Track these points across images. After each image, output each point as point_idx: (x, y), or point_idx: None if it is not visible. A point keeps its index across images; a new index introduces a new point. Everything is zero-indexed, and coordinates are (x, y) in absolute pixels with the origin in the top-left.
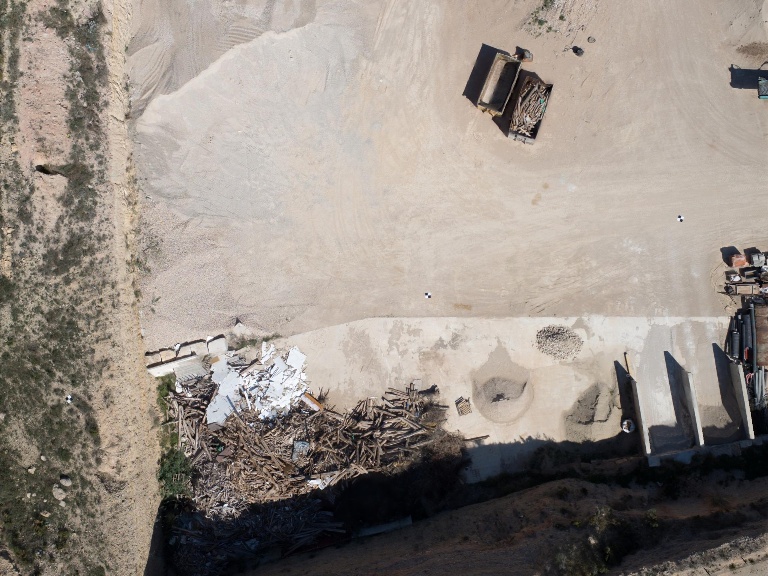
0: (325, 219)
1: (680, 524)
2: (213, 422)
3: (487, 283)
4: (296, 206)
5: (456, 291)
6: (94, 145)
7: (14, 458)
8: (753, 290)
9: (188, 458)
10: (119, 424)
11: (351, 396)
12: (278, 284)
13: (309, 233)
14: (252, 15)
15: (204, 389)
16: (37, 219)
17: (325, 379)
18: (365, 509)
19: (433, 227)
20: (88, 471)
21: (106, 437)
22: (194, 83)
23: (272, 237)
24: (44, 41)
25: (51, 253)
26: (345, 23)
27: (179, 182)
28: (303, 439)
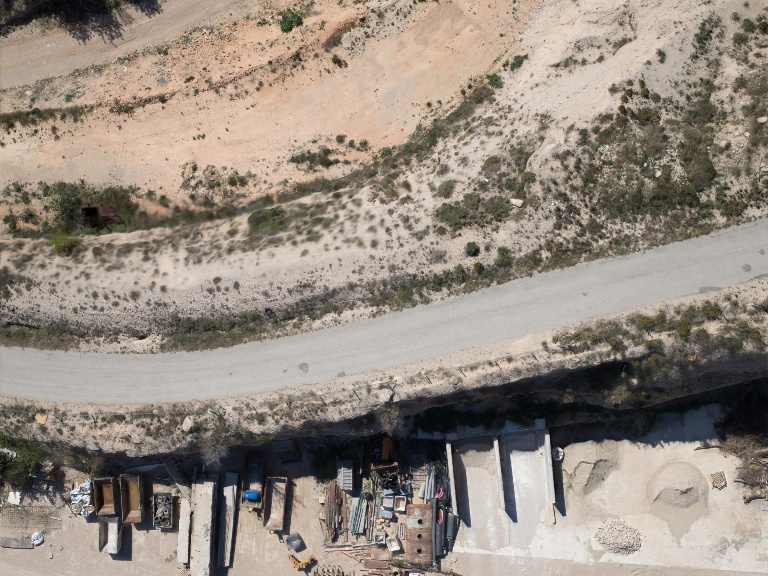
0: None
1: (543, 388)
2: None
3: None
4: None
5: None
6: None
7: None
8: None
9: None
10: None
11: None
12: None
13: None
14: None
15: None
16: None
17: None
18: None
19: None
20: None
21: None
22: None
23: None
24: None
25: None
26: None
27: None
28: None
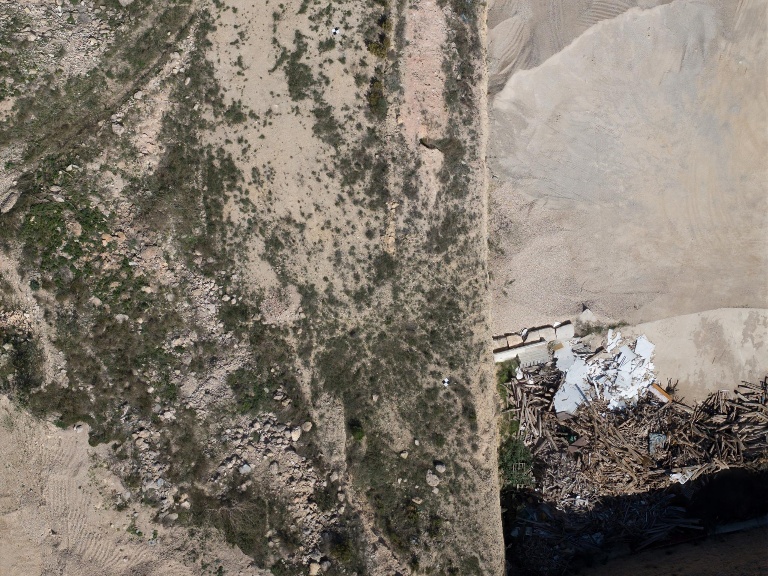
0: (677, 204)
1: None
2: (563, 411)
3: None
4: (647, 190)
5: None
6: (467, 120)
7: (385, 442)
8: None
9: (527, 447)
10: (489, 410)
11: (701, 388)
12: (625, 270)
13: (660, 218)
14: None
15: (548, 376)
16: (422, 194)
17: (674, 370)
18: (725, 506)
19: None
20: (463, 457)
21: (481, 423)
22: (553, 59)
23: (620, 221)
24: (426, 10)
25: (434, 230)
26: (707, 1)
27: (524, 161)
28: (658, 431)
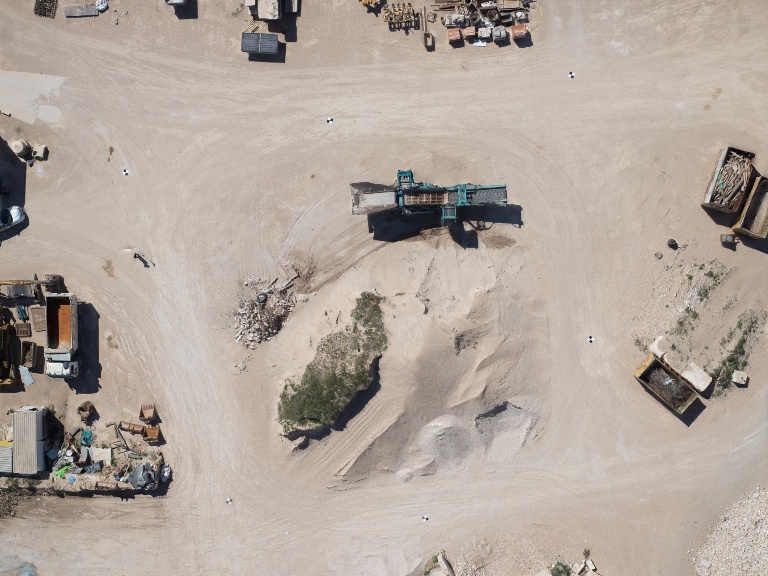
0: None
1: None
2: None
3: None
4: None
5: None
6: None
7: None
8: (503, 4)
9: None
10: None
11: None
12: None
13: None
14: None
15: None
16: None
17: None
18: None
19: None
20: None
21: None
22: None
23: None
24: None
25: None
26: None
27: None
28: None
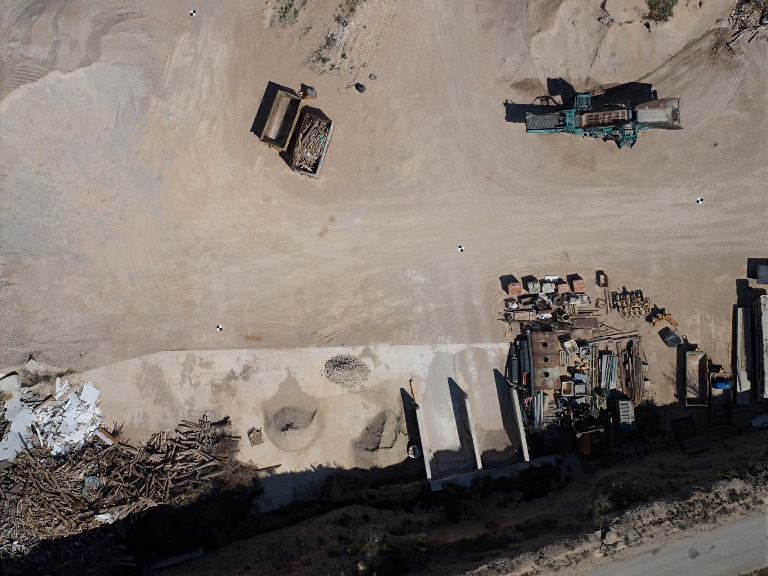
0: (117, 255)
1: (448, 547)
2: (4, 459)
3: (277, 315)
4: (89, 242)
5: (247, 323)
6: None
7: None
8: (530, 316)
9: None
10: None
11: (145, 429)
12: (72, 320)
13: (102, 269)
14: (38, 55)
15: None
16: None
17: (119, 413)
18: (155, 542)
19: (223, 261)
20: None
21: None
22: None
23: (65, 273)
24: None
25: None
26: (133, 62)
27: None
28: (94, 474)
